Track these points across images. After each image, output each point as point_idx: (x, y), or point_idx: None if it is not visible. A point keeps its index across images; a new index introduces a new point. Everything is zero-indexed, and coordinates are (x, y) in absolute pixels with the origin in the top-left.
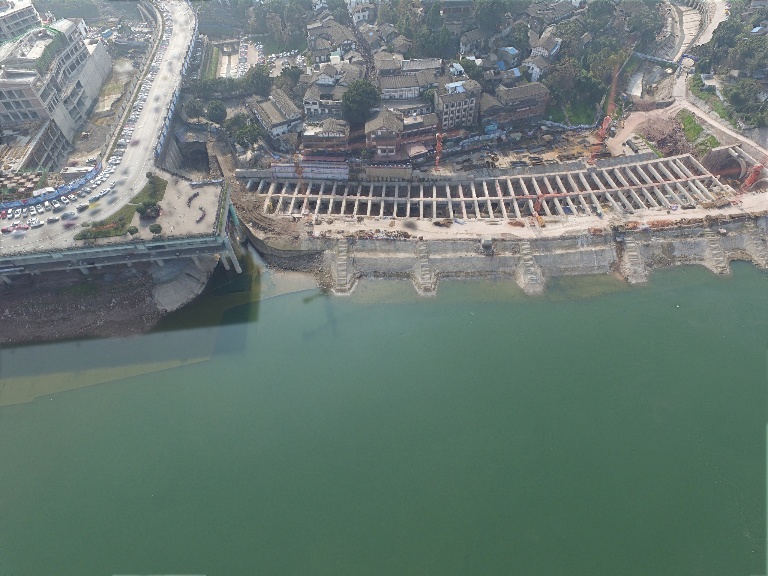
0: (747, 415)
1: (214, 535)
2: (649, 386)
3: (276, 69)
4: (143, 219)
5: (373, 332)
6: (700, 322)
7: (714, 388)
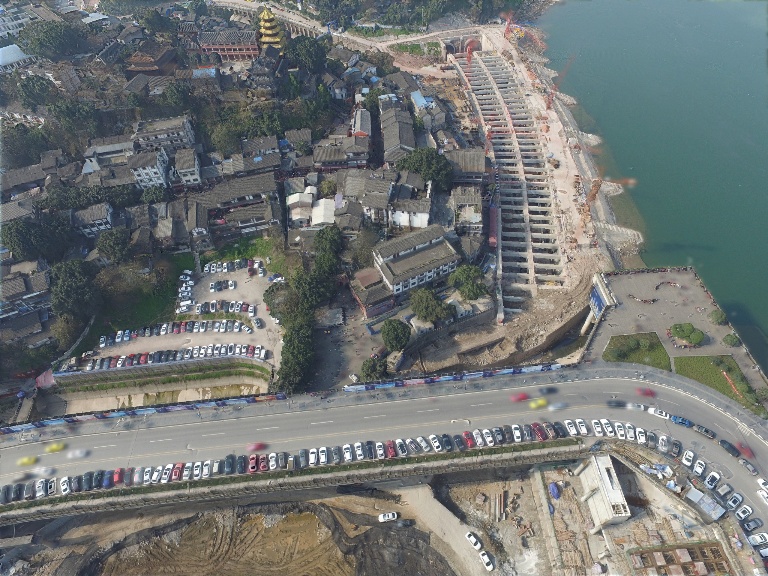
0: (662, 88)
1: None
2: (659, 111)
3: (231, 298)
4: (699, 342)
5: (673, 218)
6: (604, 87)
7: (650, 93)
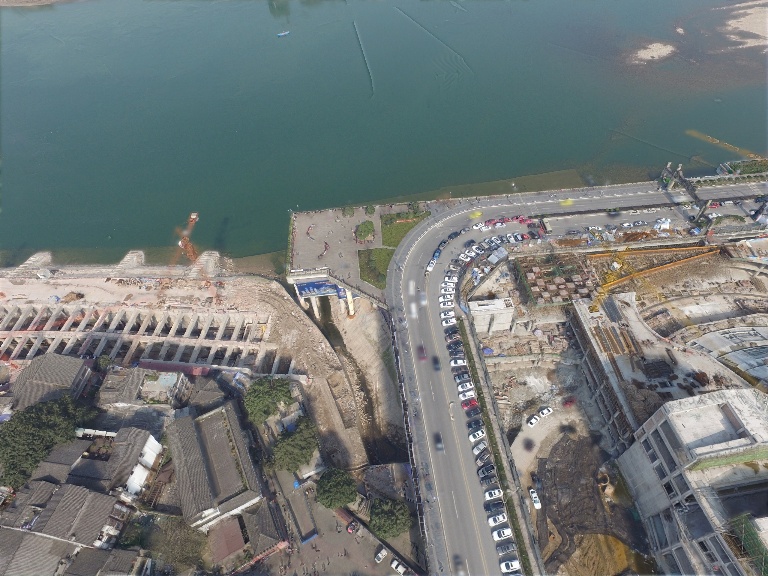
0: None
1: (292, 113)
2: (28, 195)
3: None
4: None
5: (195, 224)
6: None
7: None
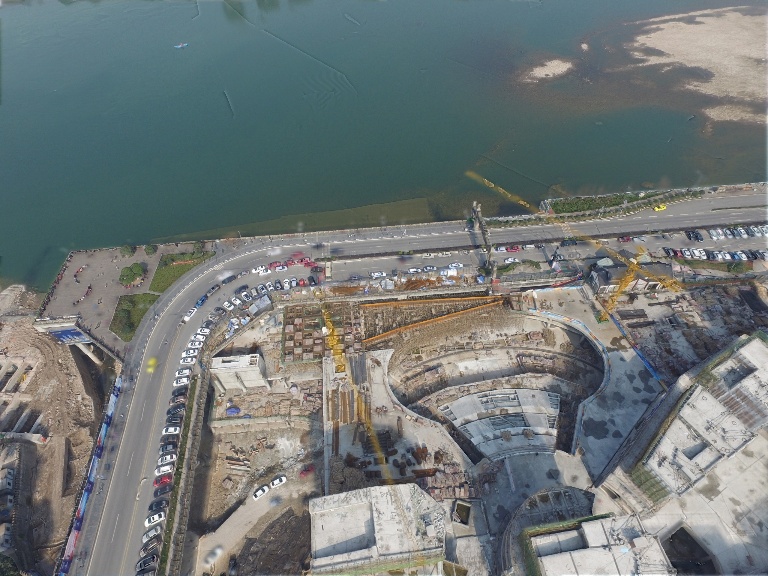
0: None
1: (140, 135)
2: None
3: None
4: None
5: (13, 254)
6: None
7: None
